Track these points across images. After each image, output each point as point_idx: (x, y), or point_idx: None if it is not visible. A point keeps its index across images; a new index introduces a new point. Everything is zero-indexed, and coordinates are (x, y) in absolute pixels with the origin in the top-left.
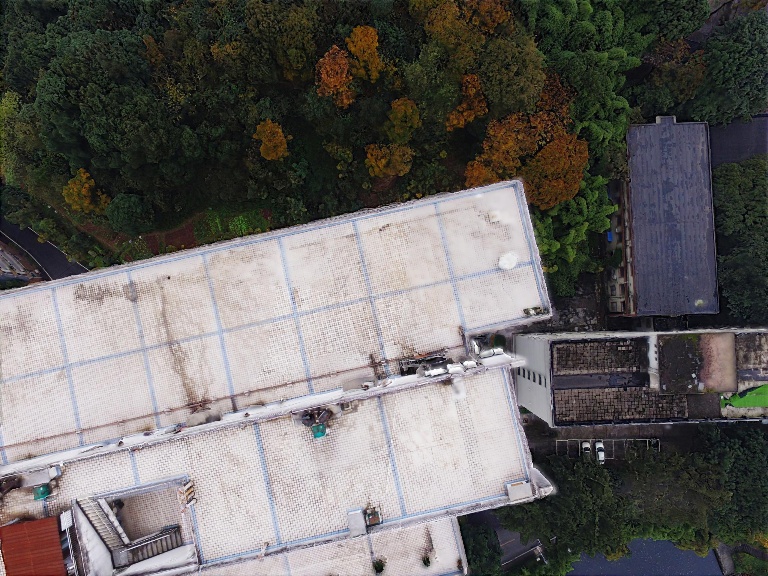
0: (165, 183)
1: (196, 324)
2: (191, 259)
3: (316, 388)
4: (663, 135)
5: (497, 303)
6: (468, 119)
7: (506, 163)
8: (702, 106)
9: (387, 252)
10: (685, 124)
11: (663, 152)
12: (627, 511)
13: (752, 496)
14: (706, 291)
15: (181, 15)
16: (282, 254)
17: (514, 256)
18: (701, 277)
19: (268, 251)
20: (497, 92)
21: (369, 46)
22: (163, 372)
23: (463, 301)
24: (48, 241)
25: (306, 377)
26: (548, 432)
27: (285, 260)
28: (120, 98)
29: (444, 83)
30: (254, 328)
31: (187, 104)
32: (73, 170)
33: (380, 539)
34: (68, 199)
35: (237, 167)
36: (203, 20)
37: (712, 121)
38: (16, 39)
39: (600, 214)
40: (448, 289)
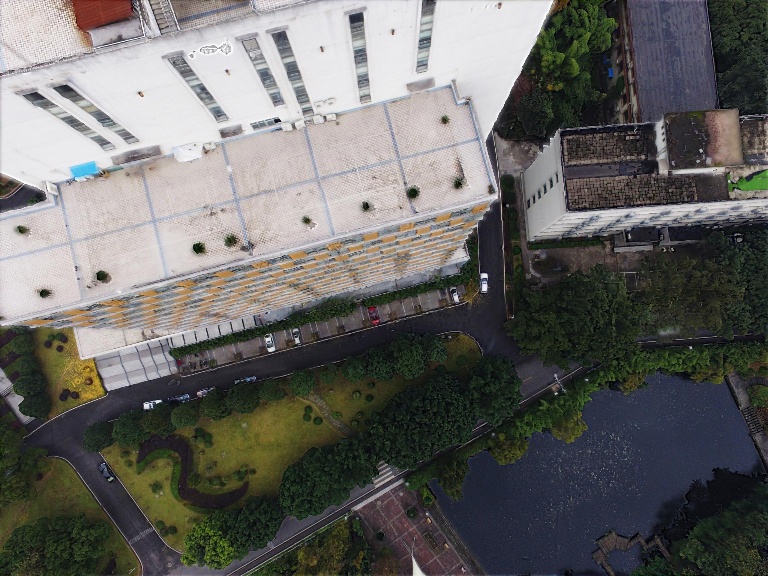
0: None
1: None
2: None
3: None
4: None
5: None
6: None
7: None
8: None
9: None
10: None
11: None
12: (642, 318)
13: (764, 292)
14: (707, 103)
15: None
16: None
17: None
18: (702, 90)
19: None
20: None
21: None
22: None
23: None
24: None
25: None
26: (560, 267)
27: None
28: None
29: None
30: None
31: None
32: None
33: (413, 170)
34: None
35: None
36: None
37: None
38: None
39: (601, 27)
40: None
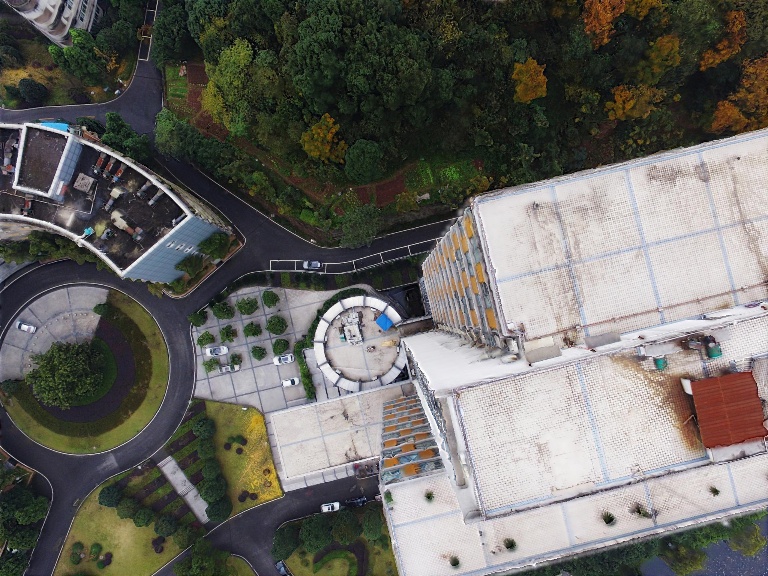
0: (405, 129)
1: (767, 203)
2: (760, 140)
3: None
4: None
5: None
6: (722, 58)
7: (763, 101)
8: None
9: None
10: None
11: None
12: None
13: None
14: None
15: None
16: None
17: None
18: None
19: None
20: (760, 29)
21: None
22: (738, 251)
23: None
24: (239, 198)
25: None
26: None
27: None
28: (388, 37)
29: (711, 20)
30: None
31: (448, 44)
32: (307, 117)
33: None
34: (309, 145)
35: (465, 114)
36: None
37: None
38: None
39: None
40: None
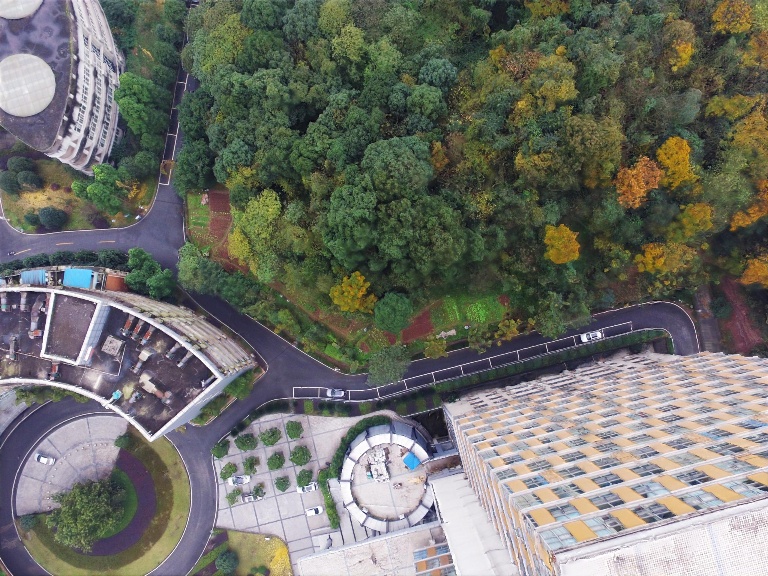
0: (434, 282)
1: None
2: None
3: None
4: None
5: None
6: (752, 219)
7: None
8: None
9: None
10: None
11: None
12: None
13: None
14: None
15: (477, 123)
16: None
17: None
18: None
19: None
20: None
21: (683, 158)
22: None
23: None
24: (261, 324)
25: None
26: None
27: None
28: (422, 209)
29: (742, 188)
30: None
31: None
32: (336, 269)
33: None
34: (339, 301)
35: (493, 260)
36: (499, 128)
37: None
38: (266, 134)
39: None
40: None
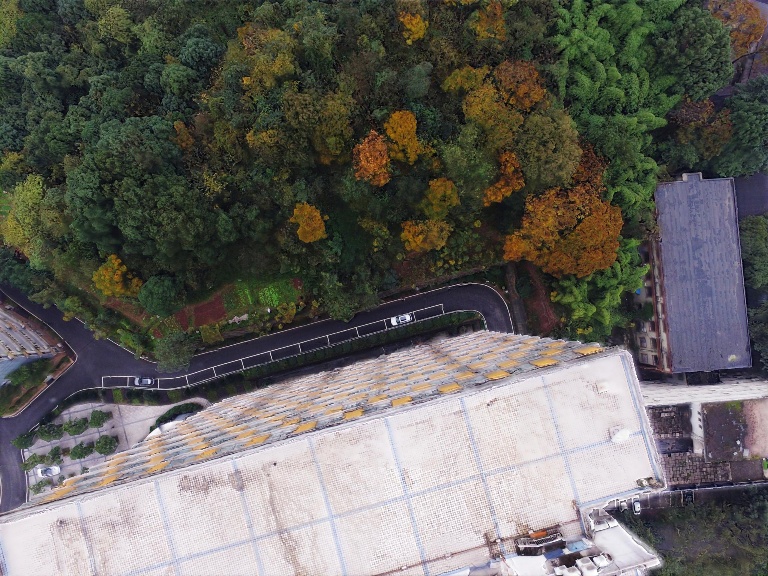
0: (198, 265)
1: (305, 511)
2: (297, 444)
3: (431, 571)
4: (690, 192)
5: (609, 475)
6: (505, 194)
7: (546, 238)
8: (727, 162)
9: (496, 427)
10: (711, 180)
11: (691, 209)
12: (670, 568)
13: None
14: (738, 346)
15: (213, 101)
16: (390, 434)
17: (627, 430)
18: (733, 332)
19: (375, 432)
20: (535, 169)
21: (409, 132)
22: (274, 563)
23: (575, 474)
24: None
25: (420, 560)
26: None
27: (393, 440)
28: (154, 189)
29: (483, 162)
30: (365, 512)
31: (222, 190)
32: (101, 253)
33: None
34: (99, 285)
35: (269, 242)
36: (236, 105)
37: (736, 174)
38: (35, 118)
39: (634, 276)
40: (559, 463)
